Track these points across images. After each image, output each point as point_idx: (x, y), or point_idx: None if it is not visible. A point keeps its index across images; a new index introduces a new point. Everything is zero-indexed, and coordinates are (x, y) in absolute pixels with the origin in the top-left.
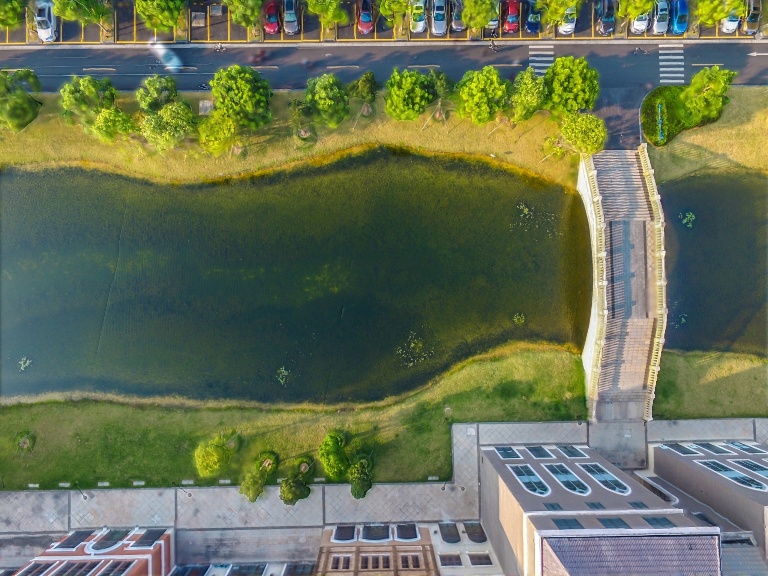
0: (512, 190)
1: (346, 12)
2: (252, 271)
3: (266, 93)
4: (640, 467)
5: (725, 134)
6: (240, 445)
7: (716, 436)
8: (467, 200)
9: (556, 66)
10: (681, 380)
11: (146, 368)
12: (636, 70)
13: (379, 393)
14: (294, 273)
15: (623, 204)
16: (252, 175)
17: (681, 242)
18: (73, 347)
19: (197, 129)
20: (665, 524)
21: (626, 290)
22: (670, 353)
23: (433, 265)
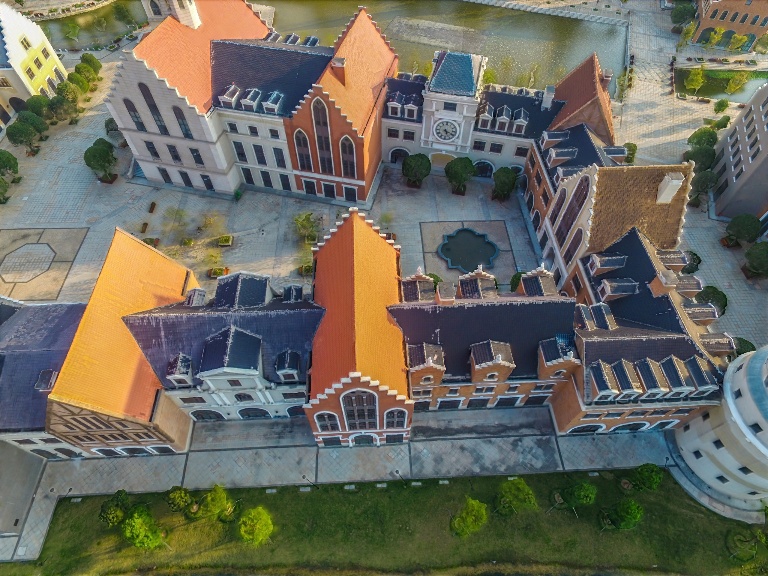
0: None
1: None
2: None
3: None
4: None
5: None
6: None
7: None
8: None
9: None
10: None
11: None
12: None
13: None
14: None
15: None
16: None
17: None
18: None
19: None
20: None
21: None
22: None
23: None
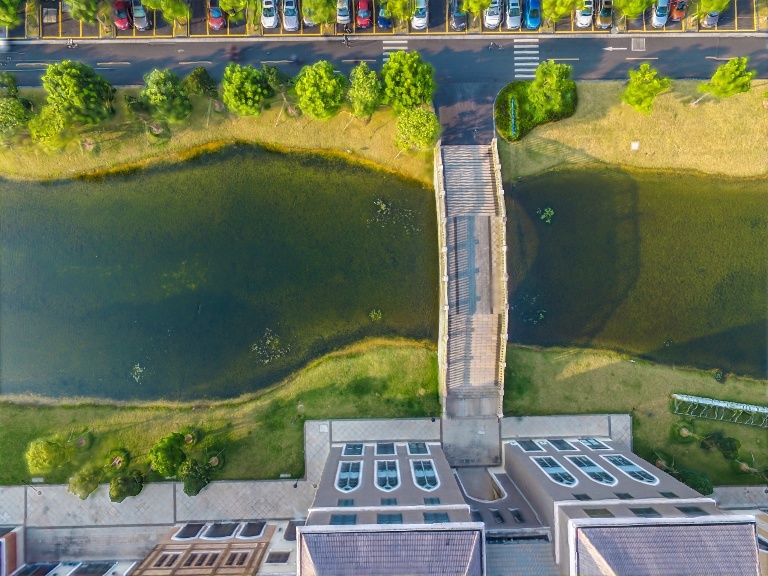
0: (369, 186)
1: (199, 8)
2: (109, 268)
3: (98, 88)
4: (494, 464)
5: (581, 129)
6: (91, 443)
7: (571, 432)
8: (324, 196)
9: (390, 60)
10: (537, 376)
11: (0, 366)
12: (491, 65)
13: (235, 390)
14: (151, 270)
15: (470, 199)
16: (107, 172)
17: (540, 238)
18: None
19: (27, 125)
20: (442, 520)
21: (470, 286)
22: (528, 349)
23: (291, 261)
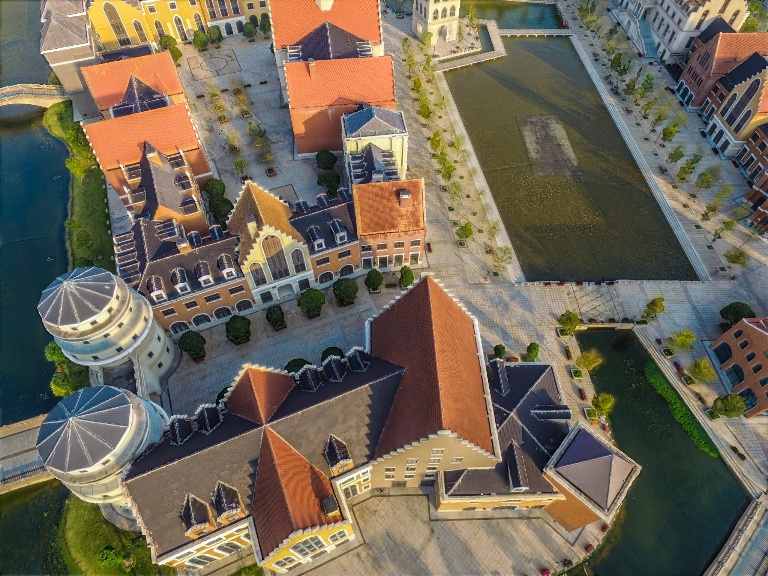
0: None
1: None
2: (6, 201)
3: None
4: None
5: None
6: None
7: None
8: None
9: None
10: None
11: None
12: None
13: (65, 151)
14: None
15: None
16: None
17: None
18: None
19: None
20: None
21: None
22: None
23: (8, 152)
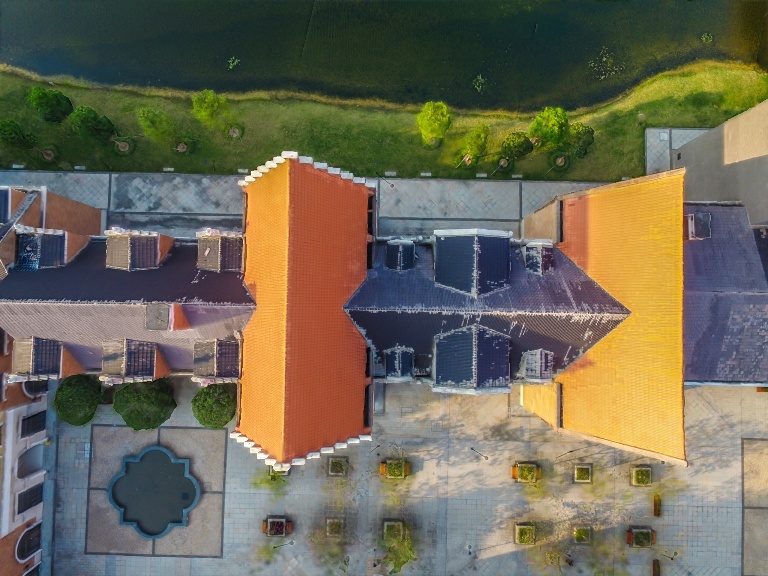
0: None
1: None
2: None
3: None
4: None
5: None
6: (441, 141)
7: None
8: None
9: None
10: None
11: (348, 72)
12: None
13: (571, 104)
14: None
15: None
16: None
17: None
18: (279, 50)
19: None
20: None
21: None
22: None
23: None
